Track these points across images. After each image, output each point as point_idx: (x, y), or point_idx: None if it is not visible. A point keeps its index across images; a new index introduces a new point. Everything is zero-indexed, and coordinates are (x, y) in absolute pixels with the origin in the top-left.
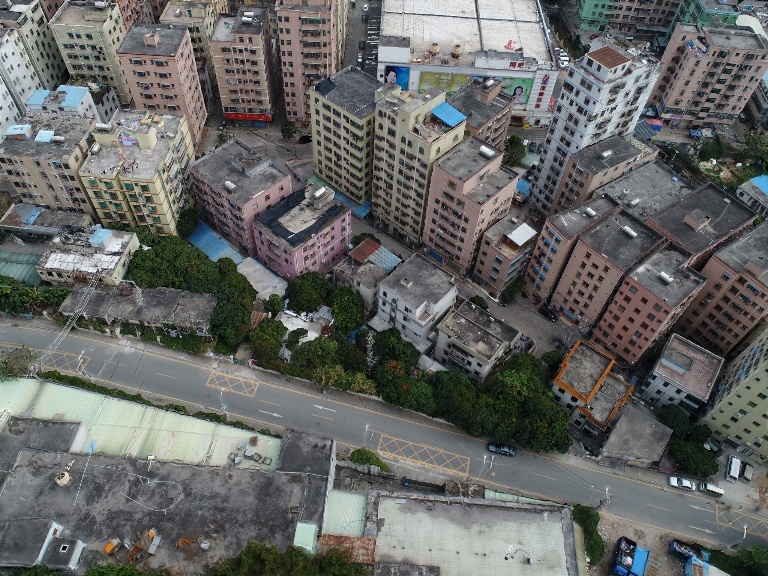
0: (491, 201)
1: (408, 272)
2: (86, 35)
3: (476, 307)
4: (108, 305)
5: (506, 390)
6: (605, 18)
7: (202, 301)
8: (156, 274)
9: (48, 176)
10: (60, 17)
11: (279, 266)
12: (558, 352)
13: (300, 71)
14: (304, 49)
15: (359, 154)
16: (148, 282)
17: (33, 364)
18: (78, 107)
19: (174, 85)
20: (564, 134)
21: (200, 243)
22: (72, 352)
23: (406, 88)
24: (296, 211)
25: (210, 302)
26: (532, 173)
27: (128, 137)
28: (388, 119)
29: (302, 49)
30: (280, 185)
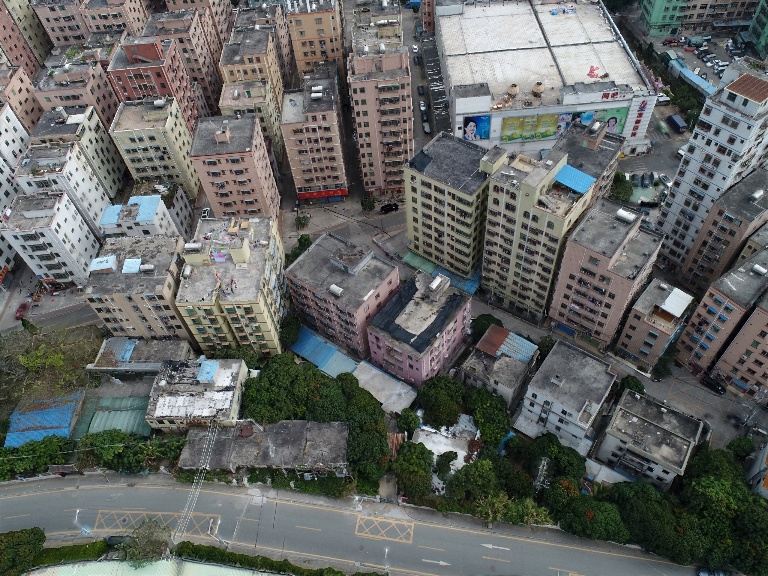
0: (641, 273)
1: (555, 366)
2: (149, 137)
3: (641, 397)
4: (230, 451)
5: (712, 506)
6: (677, 20)
7: (332, 432)
8: (275, 406)
9: (141, 309)
10: (118, 122)
11: (400, 370)
12: (747, 439)
13: (378, 140)
14: (382, 118)
15: (468, 230)
16: (268, 417)
17: (164, 539)
18: (154, 219)
19: (251, 180)
20: (699, 176)
21: (305, 351)
22: (199, 511)
23: (487, 137)
24: (411, 307)
25: (341, 432)
26: (643, 211)
27: (220, 253)
28: (506, 194)
29: (379, 118)
30: (389, 280)
